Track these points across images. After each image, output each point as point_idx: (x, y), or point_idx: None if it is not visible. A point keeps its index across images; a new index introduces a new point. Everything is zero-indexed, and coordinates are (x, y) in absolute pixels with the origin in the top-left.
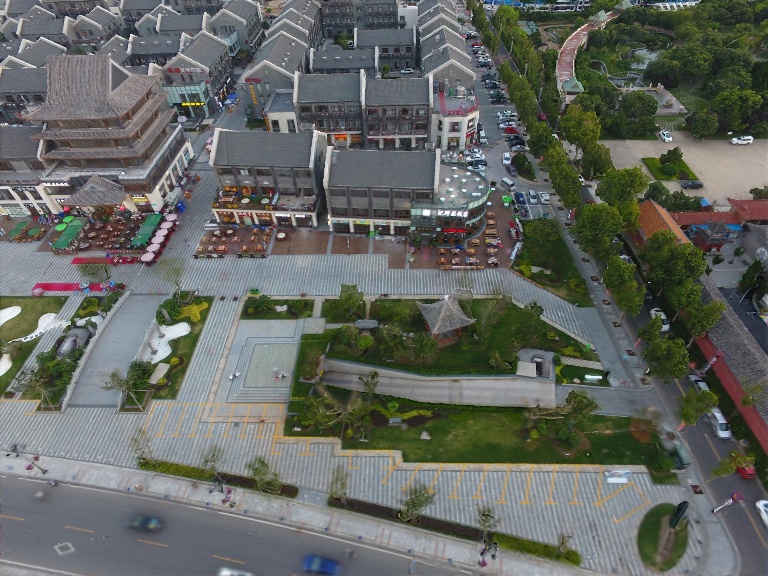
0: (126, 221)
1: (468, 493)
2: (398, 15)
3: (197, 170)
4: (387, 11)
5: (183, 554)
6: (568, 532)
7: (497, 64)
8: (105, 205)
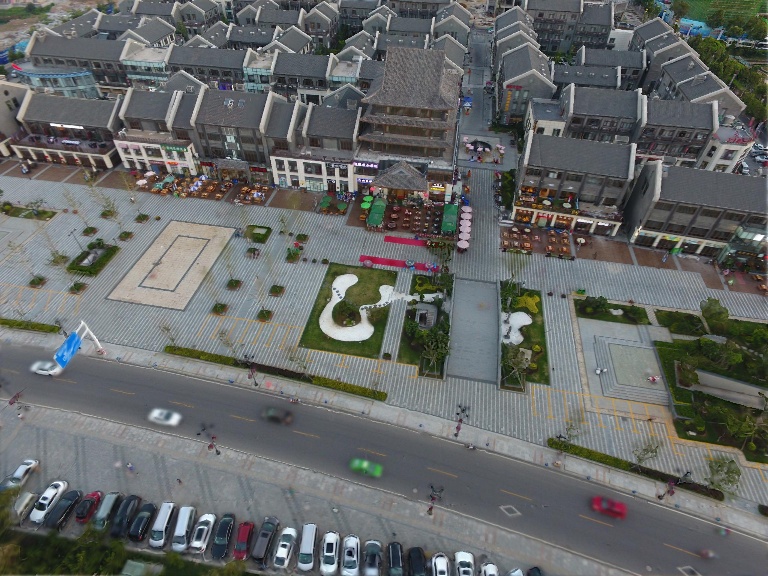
0: (419, 207)
1: None
2: (609, 37)
3: (463, 167)
4: (599, 32)
5: (631, 536)
6: None
7: None
8: (411, 190)
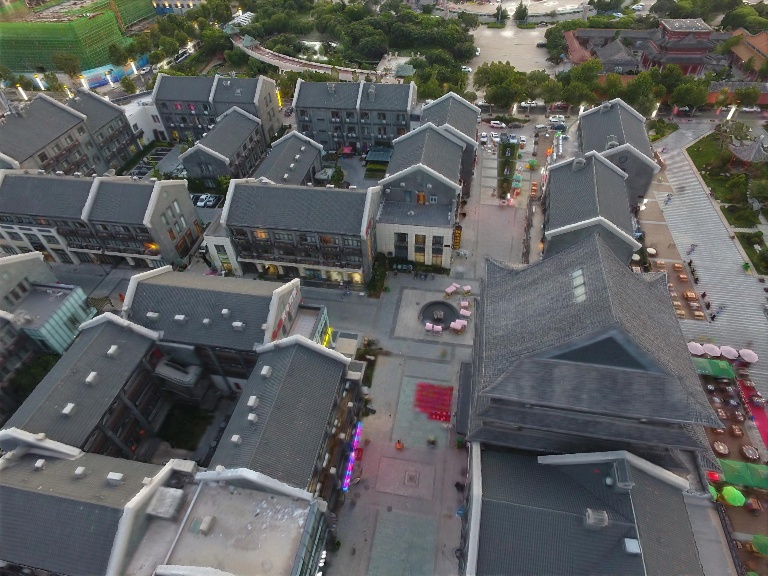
0: None
1: None
2: (130, 126)
3: None
4: (118, 128)
5: None
6: None
7: (287, 106)
8: None
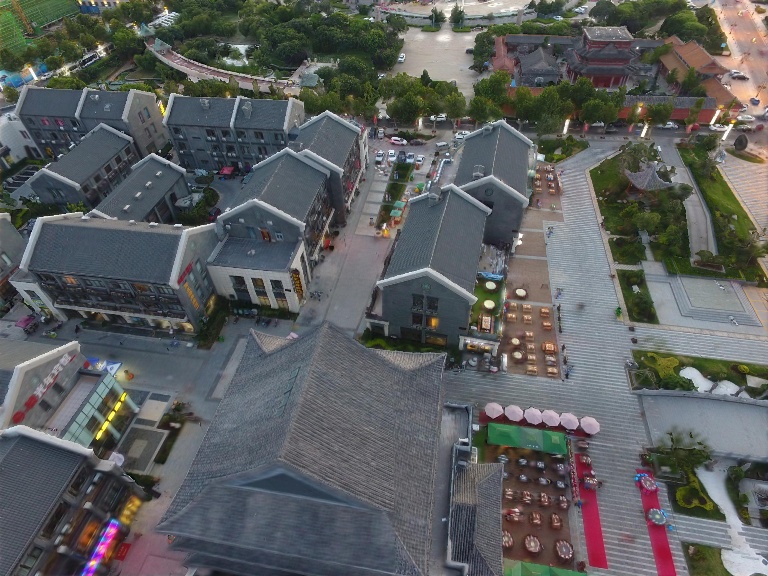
0: None
1: (762, 208)
2: None
3: None
4: None
5: None
6: (763, 180)
7: None
8: (500, 496)
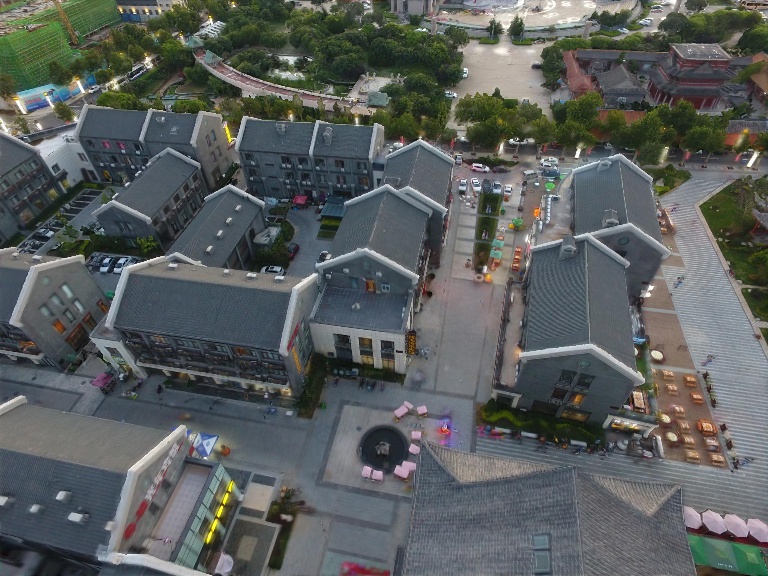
0: None
1: None
2: (48, 168)
3: None
4: (30, 172)
5: None
6: None
7: None
8: None
